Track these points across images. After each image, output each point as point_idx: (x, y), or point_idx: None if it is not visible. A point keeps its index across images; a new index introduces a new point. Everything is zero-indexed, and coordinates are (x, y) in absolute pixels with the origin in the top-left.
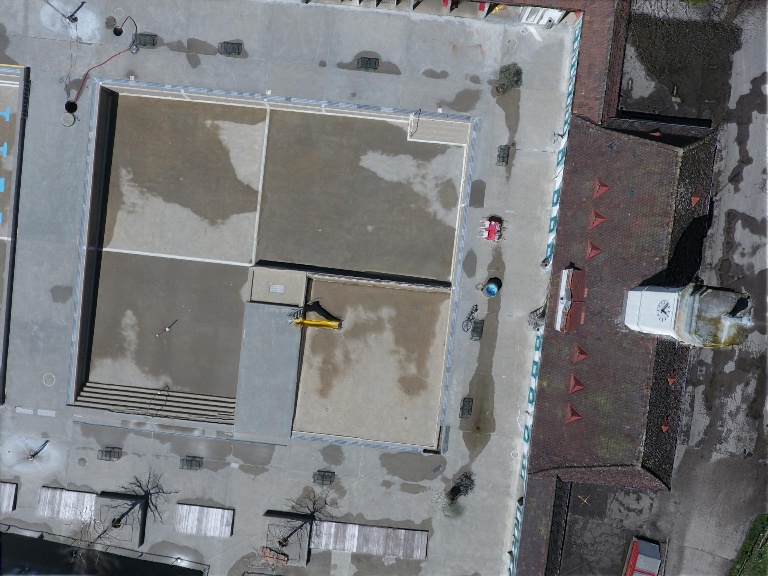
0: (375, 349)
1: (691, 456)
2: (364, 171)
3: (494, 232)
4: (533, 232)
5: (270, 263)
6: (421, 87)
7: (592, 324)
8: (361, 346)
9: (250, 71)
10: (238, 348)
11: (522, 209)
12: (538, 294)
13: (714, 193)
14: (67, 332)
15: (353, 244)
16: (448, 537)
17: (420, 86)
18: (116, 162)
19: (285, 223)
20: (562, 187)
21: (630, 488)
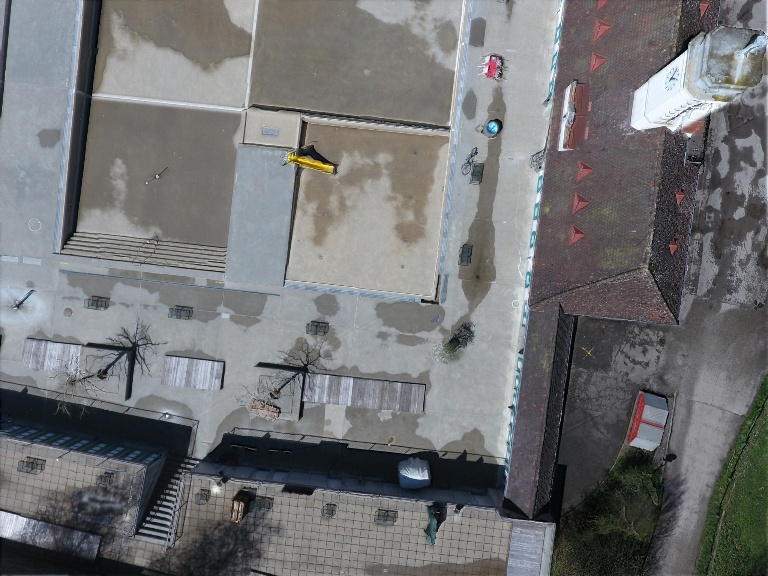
0: (371, 195)
1: (699, 307)
2: (361, 12)
3: (494, 67)
4: (535, 71)
5: (263, 108)
6: None
7: (596, 136)
8: (357, 192)
9: None
10: (230, 194)
11: (523, 48)
12: (540, 136)
13: None
14: (54, 177)
15: (349, 88)
16: (446, 391)
17: None
18: (106, 4)
19: (279, 66)
20: (565, 5)
21: (636, 340)
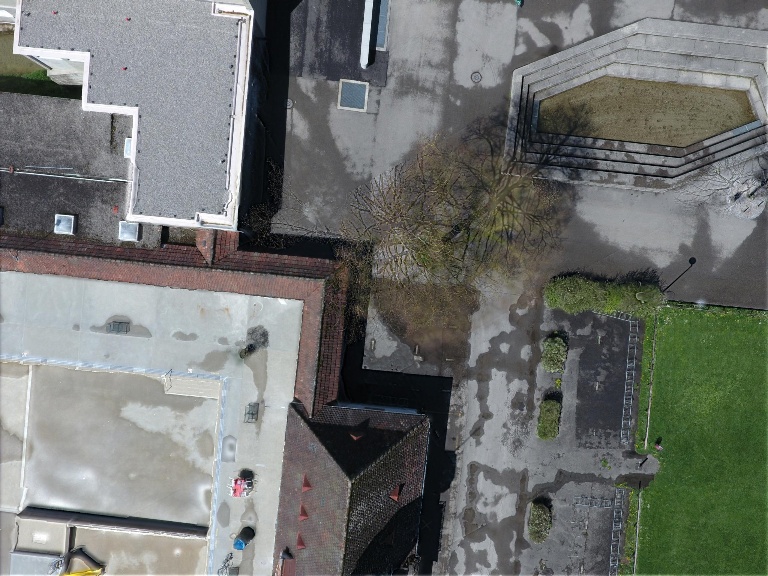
0: None
1: None
2: (125, 422)
3: (239, 491)
4: None
5: (37, 510)
6: (171, 349)
7: None
8: None
9: (6, 335)
10: None
11: (272, 463)
12: None
13: (456, 446)
14: None
15: (116, 491)
16: None
17: (170, 348)
18: None
19: (50, 471)
20: (282, 471)
21: None
